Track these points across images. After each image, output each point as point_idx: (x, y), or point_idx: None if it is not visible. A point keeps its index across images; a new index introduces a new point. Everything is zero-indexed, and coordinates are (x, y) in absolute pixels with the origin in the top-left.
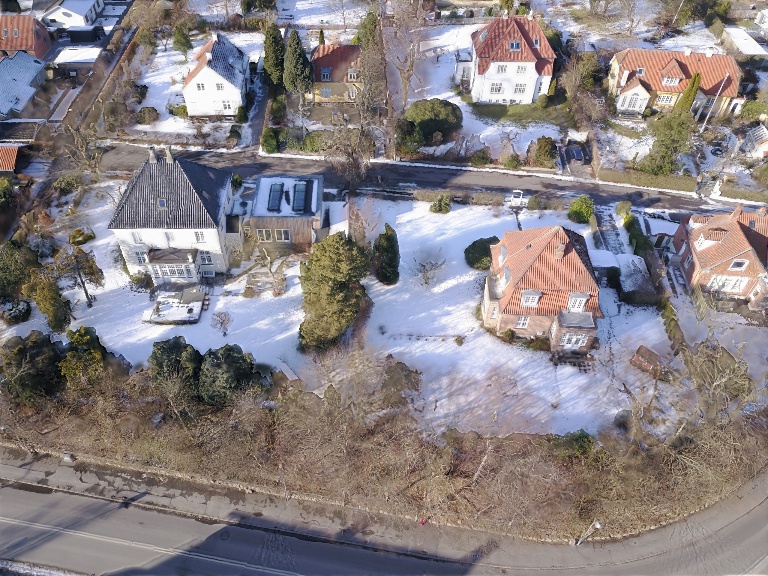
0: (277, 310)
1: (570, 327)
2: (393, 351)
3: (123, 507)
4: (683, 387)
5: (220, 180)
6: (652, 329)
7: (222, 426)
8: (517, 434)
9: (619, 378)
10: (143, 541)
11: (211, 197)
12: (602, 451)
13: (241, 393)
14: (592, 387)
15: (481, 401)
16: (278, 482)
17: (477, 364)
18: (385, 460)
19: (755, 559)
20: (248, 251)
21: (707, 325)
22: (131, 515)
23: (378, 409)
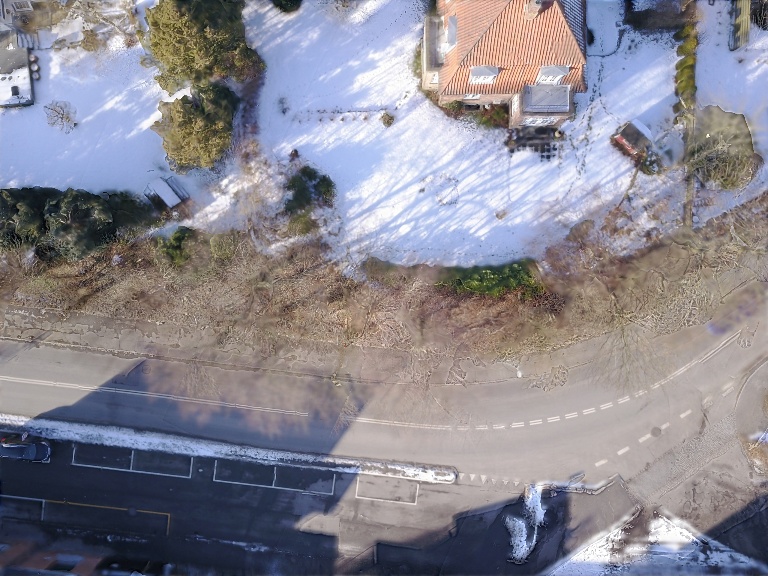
0: (135, 75)
1: (534, 115)
2: (299, 143)
3: (34, 347)
4: (668, 182)
5: None
6: (656, 78)
7: (106, 262)
8: (446, 271)
9: (590, 168)
10: (66, 381)
11: None
12: (542, 290)
13: (110, 243)
14: (552, 184)
15: (410, 215)
16: (187, 315)
17: (408, 158)
18: (299, 292)
19: (681, 366)
20: None
21: (738, 58)
22: (45, 355)
23: (284, 238)
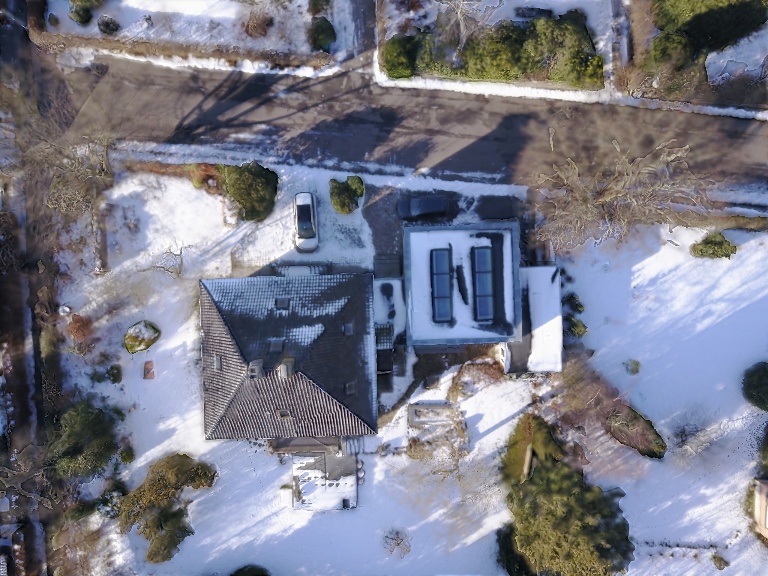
0: (462, 490)
1: None
2: None
3: None
4: None
5: (360, 319)
6: None
7: None
8: None
9: None
10: None
11: (357, 379)
12: None
13: None
14: None
15: None
16: None
17: None
18: None
19: None
20: (401, 363)
21: None
22: None
23: None
